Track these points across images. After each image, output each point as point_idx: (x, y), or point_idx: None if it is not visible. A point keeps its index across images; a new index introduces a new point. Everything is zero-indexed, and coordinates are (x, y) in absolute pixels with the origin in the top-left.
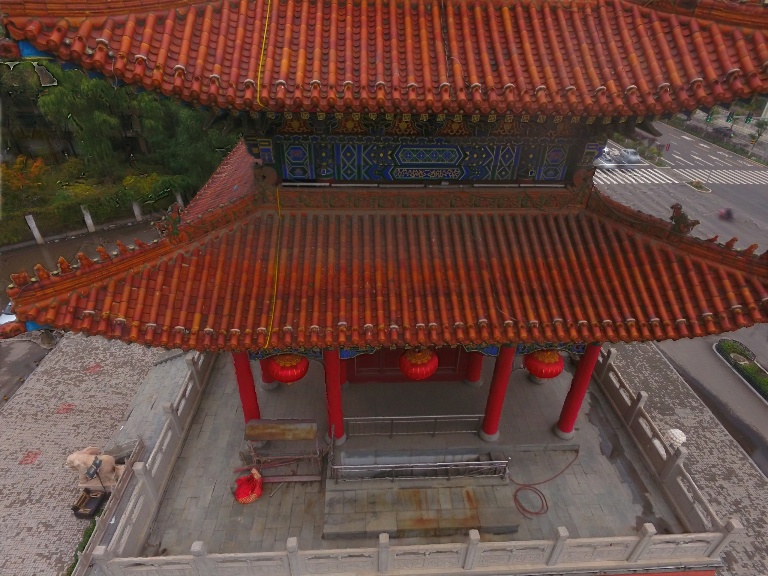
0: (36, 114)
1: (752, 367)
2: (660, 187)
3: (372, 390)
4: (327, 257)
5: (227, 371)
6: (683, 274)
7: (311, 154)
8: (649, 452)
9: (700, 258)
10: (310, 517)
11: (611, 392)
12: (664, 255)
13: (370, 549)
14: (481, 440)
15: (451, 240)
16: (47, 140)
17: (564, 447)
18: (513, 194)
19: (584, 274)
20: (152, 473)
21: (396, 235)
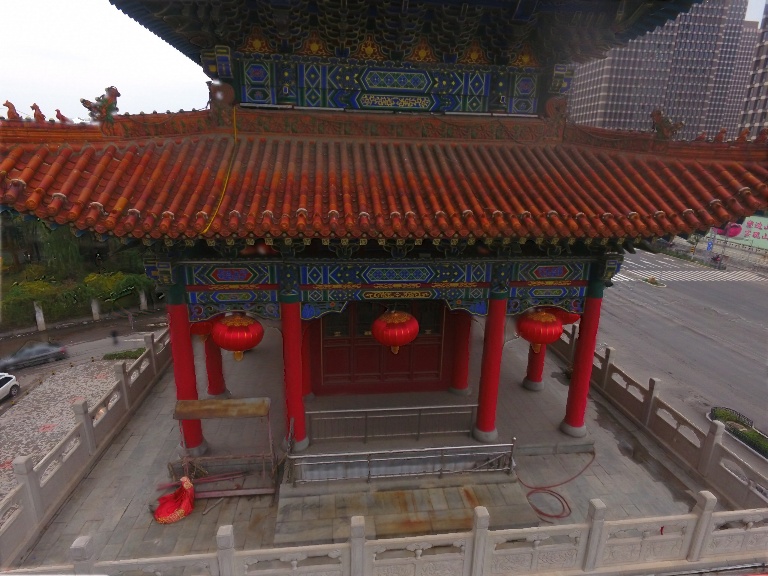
0: (5, 216)
1: (752, 433)
2: (619, 284)
3: (342, 401)
4: (287, 169)
5: (166, 394)
6: (677, 177)
7: (273, 75)
8: (677, 446)
9: (691, 159)
10: (256, 534)
11: (618, 396)
12: (653, 166)
13: (338, 545)
14: (476, 441)
15: (425, 163)
16: (11, 241)
17: (577, 448)
18: (486, 123)
19: (572, 186)
20: (41, 483)
21: (365, 157)
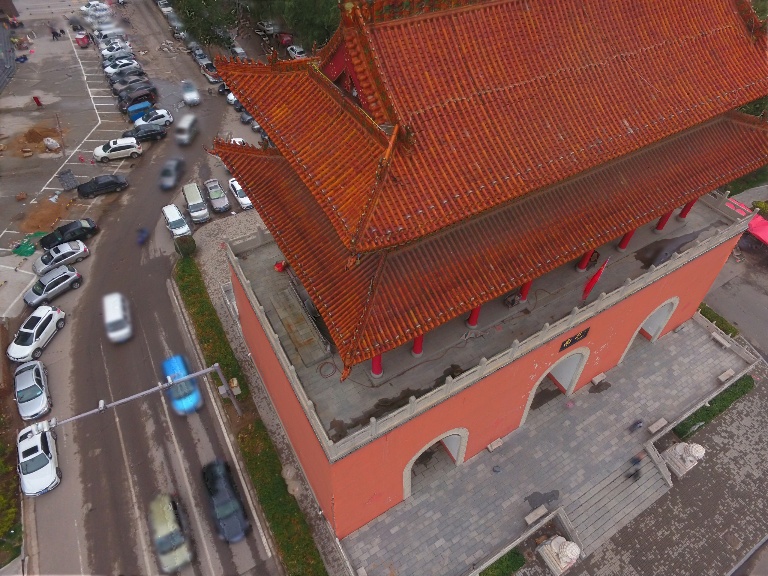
0: None
1: None
2: None
3: None
4: None
5: None
6: None
7: None
8: None
9: None
10: None
11: None
12: None
13: None
14: None
15: None
16: None
17: None
18: None
19: None
20: None
21: None
